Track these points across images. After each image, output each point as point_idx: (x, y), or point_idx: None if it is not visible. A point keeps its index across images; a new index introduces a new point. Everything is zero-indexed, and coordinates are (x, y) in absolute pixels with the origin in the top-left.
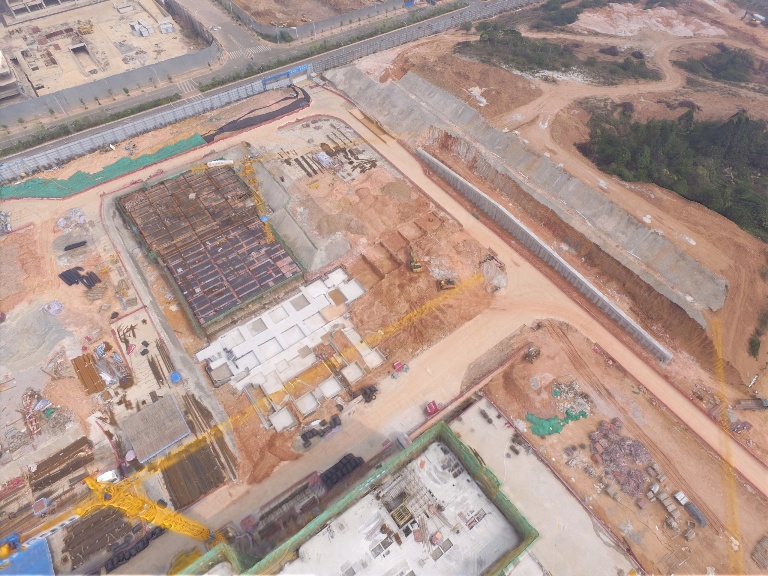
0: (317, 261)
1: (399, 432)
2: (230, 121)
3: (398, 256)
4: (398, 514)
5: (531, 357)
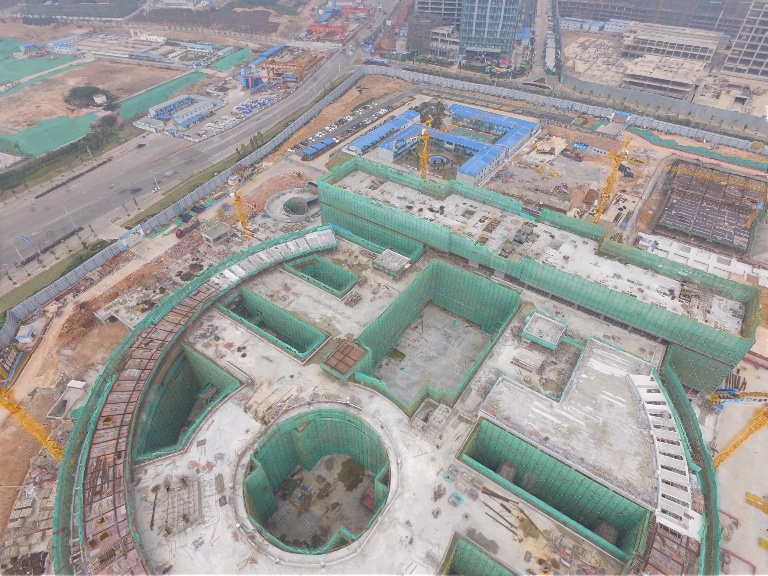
0: (764, 256)
1: None
2: None
3: None
4: (685, 295)
5: None
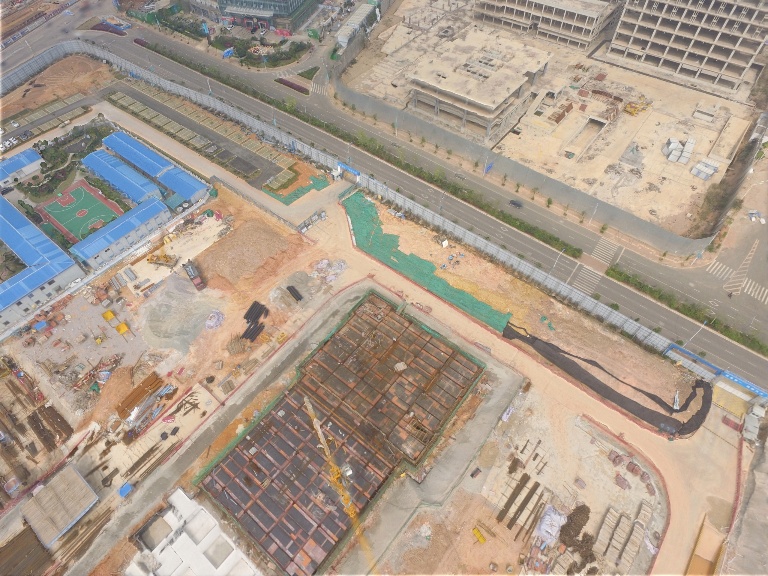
0: None
1: None
2: (554, 343)
3: None
4: None
5: None
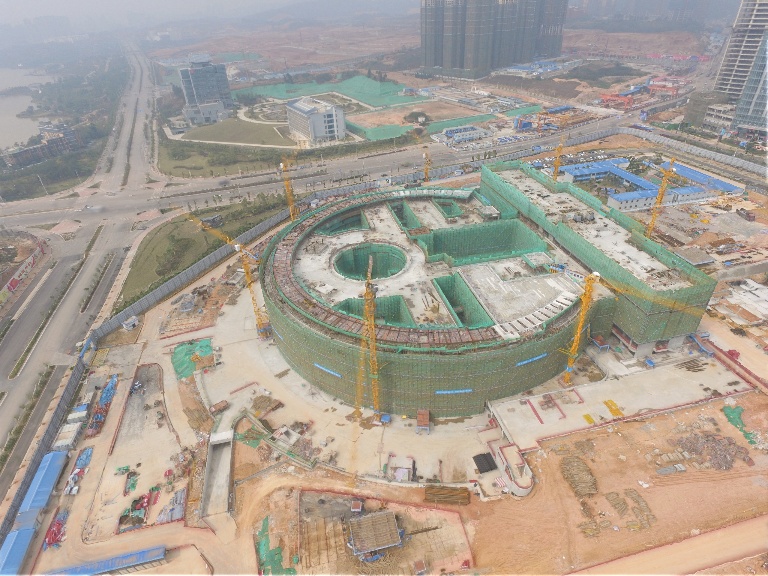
0: None
1: (710, 338)
2: None
3: None
4: None
5: None
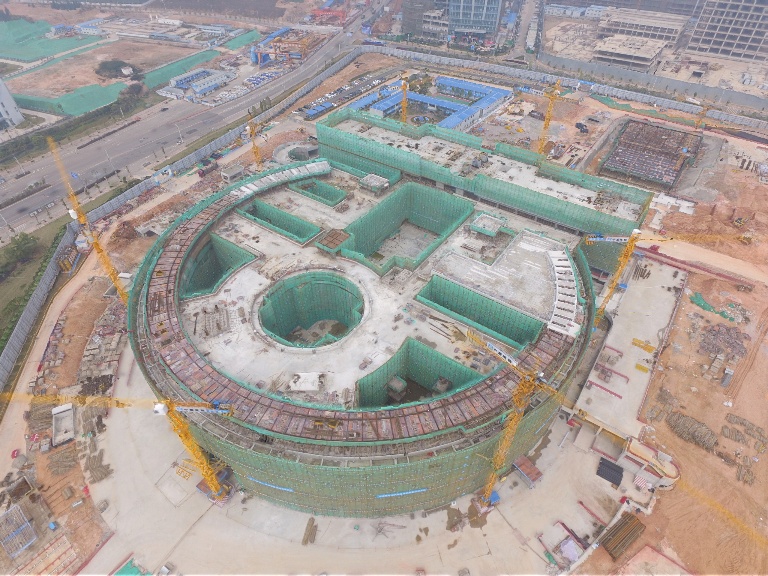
0: (686, 191)
1: None
2: (732, 128)
3: (735, 217)
4: (599, 200)
5: (742, 286)
